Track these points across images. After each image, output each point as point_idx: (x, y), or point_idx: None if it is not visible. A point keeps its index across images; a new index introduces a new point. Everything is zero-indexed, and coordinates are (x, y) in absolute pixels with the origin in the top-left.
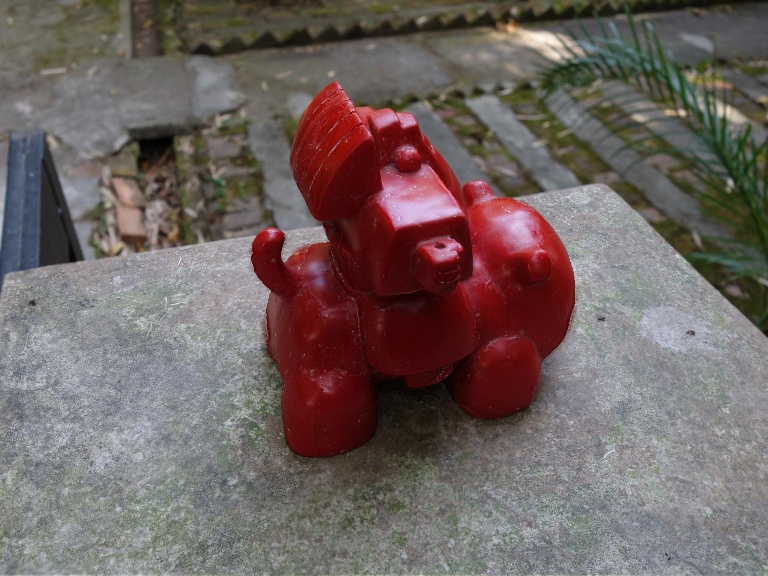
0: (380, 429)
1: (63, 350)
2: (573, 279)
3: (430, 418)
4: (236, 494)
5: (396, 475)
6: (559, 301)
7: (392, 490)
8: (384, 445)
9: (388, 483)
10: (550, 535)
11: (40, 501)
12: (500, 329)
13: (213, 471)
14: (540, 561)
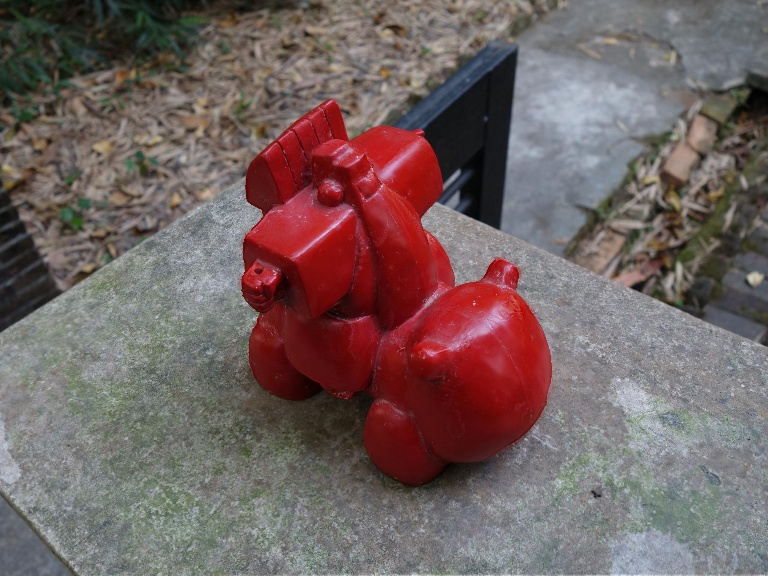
0: (310, 401)
1: (255, 209)
2: (505, 413)
3: (345, 425)
4: (201, 360)
5: (274, 435)
6: (452, 415)
7: (258, 441)
8: (297, 412)
9: (263, 435)
10: (283, 569)
11: (143, 283)
12: (392, 395)
13: (211, 338)
14: (253, 573)
